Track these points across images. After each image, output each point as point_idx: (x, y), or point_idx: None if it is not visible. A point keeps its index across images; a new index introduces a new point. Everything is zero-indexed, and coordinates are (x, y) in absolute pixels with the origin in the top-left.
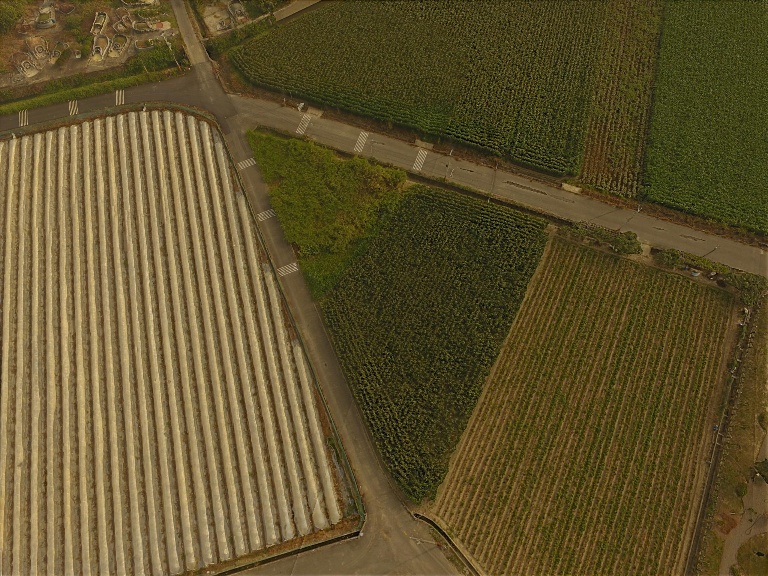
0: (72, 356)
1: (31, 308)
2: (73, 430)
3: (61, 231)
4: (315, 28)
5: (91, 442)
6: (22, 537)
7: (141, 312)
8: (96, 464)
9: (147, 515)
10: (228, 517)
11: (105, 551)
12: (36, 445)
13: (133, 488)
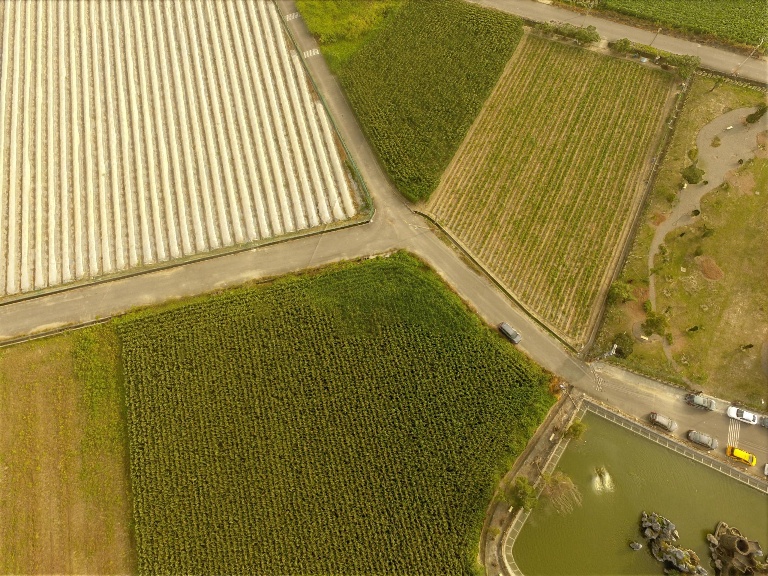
0: (139, 109)
1: (104, 76)
2: (143, 156)
3: (126, 24)
4: None
5: (158, 164)
6: (108, 221)
7: (193, 81)
8: (163, 175)
9: (204, 210)
10: (267, 212)
11: (173, 228)
12: (115, 163)
13: (193, 190)
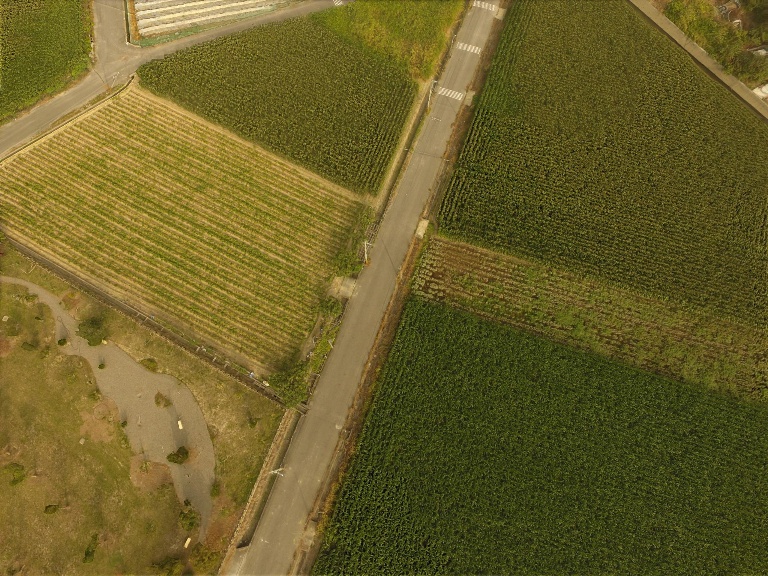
0: None
1: None
2: None
3: None
4: (604, 6)
5: None
6: None
7: None
8: None
9: None
10: None
11: None
12: None
13: None
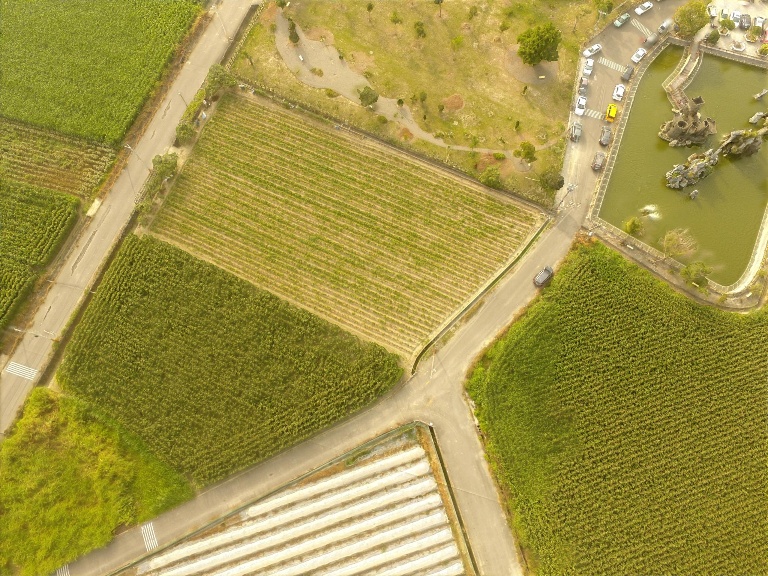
0: None
1: None
2: None
3: None
4: None
5: None
6: None
7: None
8: None
9: None
10: (425, 571)
11: None
12: None
13: None
